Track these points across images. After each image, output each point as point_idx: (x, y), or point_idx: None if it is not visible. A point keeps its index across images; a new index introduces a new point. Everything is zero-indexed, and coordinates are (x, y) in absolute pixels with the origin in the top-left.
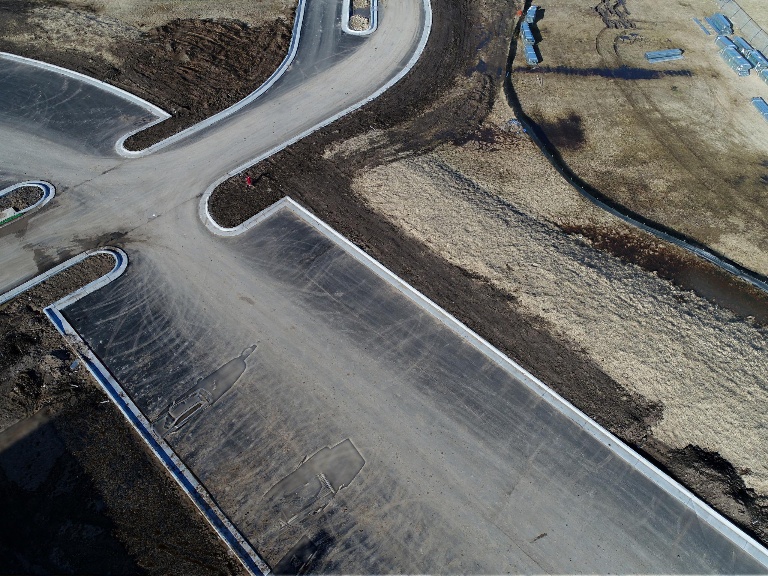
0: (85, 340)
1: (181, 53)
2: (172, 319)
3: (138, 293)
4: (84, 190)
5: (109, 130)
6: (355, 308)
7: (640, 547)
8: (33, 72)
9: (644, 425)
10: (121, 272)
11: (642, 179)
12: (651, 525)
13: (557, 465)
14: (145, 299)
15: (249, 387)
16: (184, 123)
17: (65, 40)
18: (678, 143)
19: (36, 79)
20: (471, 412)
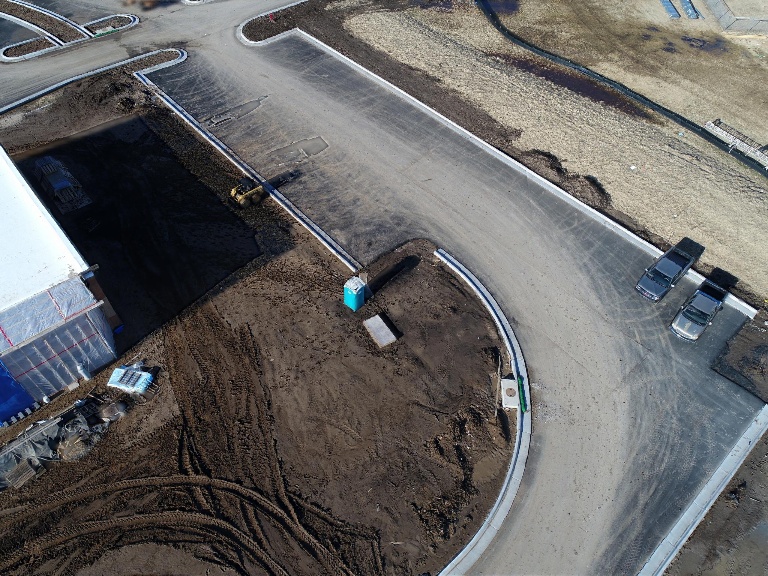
0: (160, 88)
1: None
2: (215, 82)
3: (194, 70)
4: (159, 20)
5: None
6: (334, 82)
7: (487, 187)
8: None
9: (508, 140)
10: (183, 60)
11: (554, 32)
12: (497, 179)
13: (447, 153)
14: (198, 73)
15: (261, 113)
16: None
17: None
18: (589, 14)
19: None
20: (399, 130)
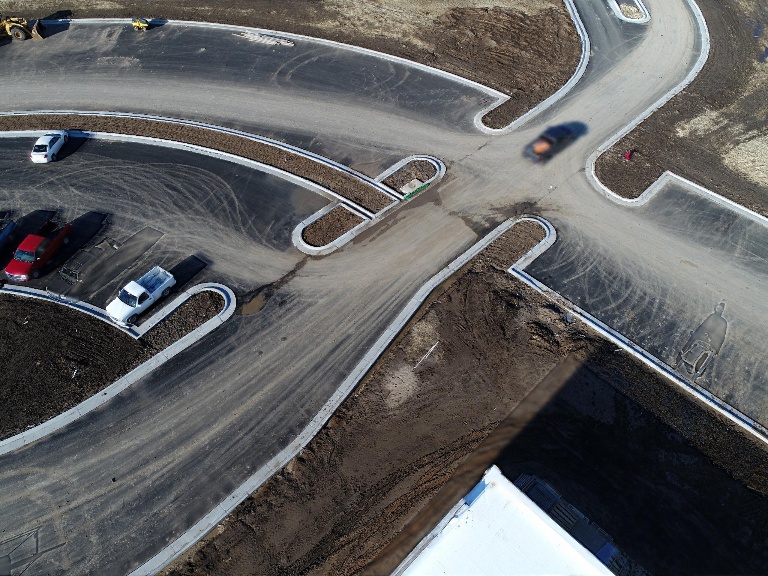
0: (564, 296)
1: (485, 39)
2: (630, 279)
3: (583, 256)
4: (471, 164)
5: (459, 110)
6: None
7: None
8: (354, 56)
9: None
10: (555, 237)
11: None
12: None
13: None
14: (593, 261)
15: (741, 339)
16: (527, 104)
17: (370, 27)
18: None
19: (361, 63)
20: None
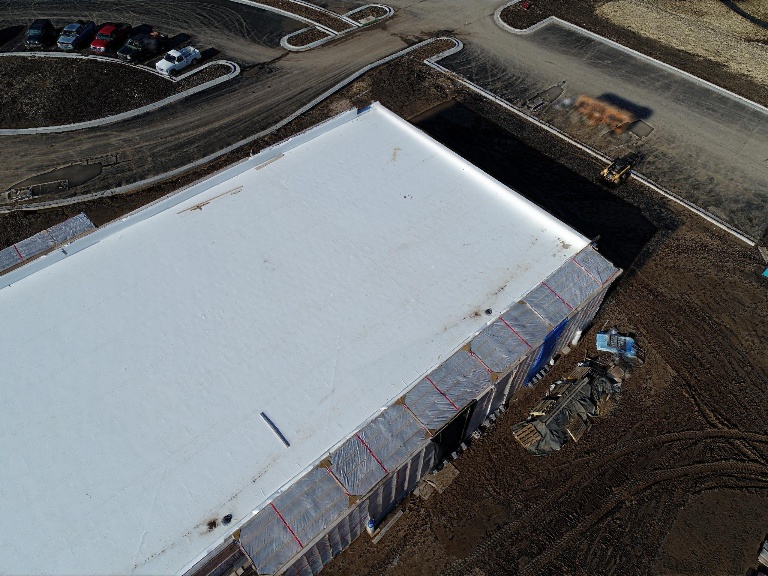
0: None
1: None
2: (506, 69)
3: (478, 57)
4: (413, 10)
5: None
6: (621, 68)
7: None
8: None
9: None
10: (461, 48)
11: None
12: None
13: None
14: (484, 60)
15: (570, 98)
16: None
17: None
18: None
19: None
20: (711, 113)
